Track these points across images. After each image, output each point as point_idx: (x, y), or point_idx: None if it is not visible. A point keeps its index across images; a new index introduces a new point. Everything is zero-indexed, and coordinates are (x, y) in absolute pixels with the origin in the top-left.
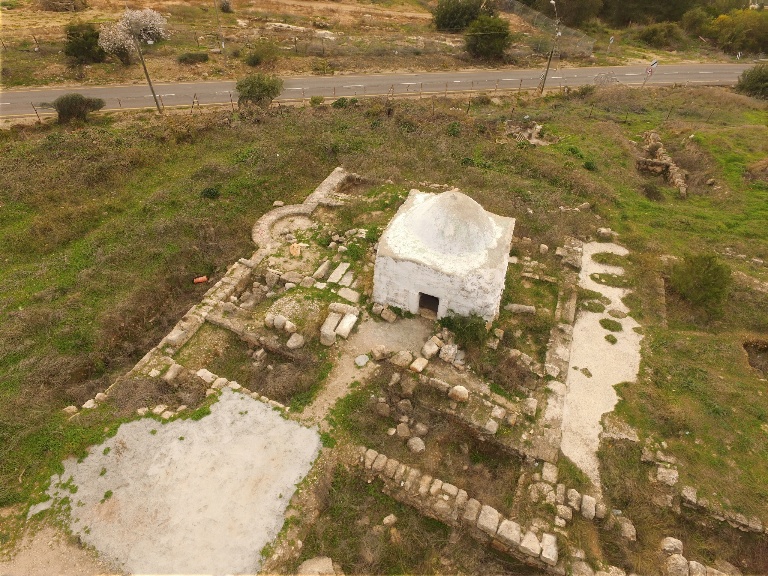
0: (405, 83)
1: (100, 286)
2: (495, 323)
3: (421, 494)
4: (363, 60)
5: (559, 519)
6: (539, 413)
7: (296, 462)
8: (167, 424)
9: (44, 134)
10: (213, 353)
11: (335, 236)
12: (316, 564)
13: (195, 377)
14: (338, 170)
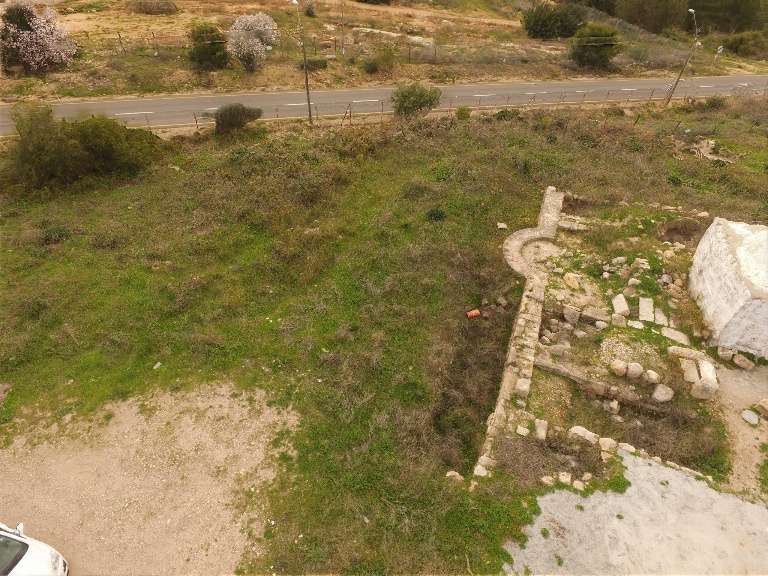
0: (531, 93)
1: (400, 324)
2: None
3: None
4: (475, 68)
5: None
6: None
7: None
8: (589, 498)
9: (206, 146)
10: (564, 405)
11: (607, 266)
12: None
13: (573, 436)
14: (552, 189)
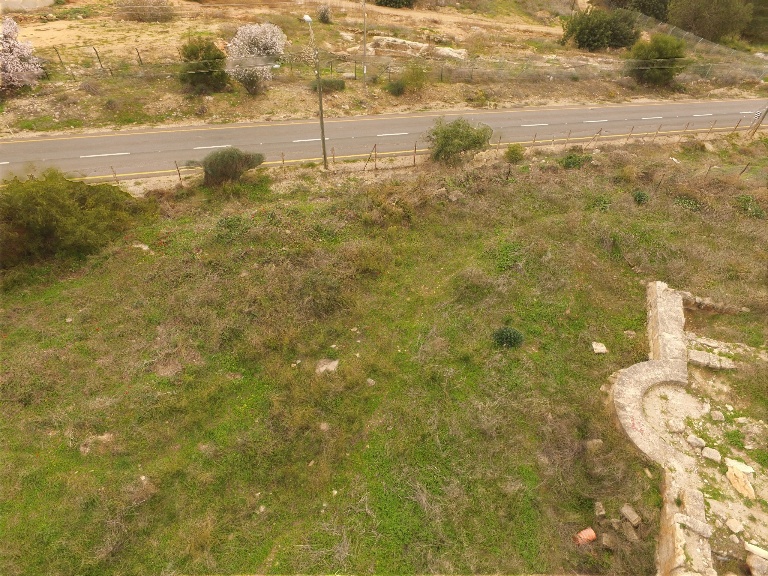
0: (589, 121)
1: None
2: None
3: None
4: (518, 88)
5: None
6: None
7: None
8: None
9: (190, 204)
10: None
11: None
12: None
13: None
14: (664, 287)
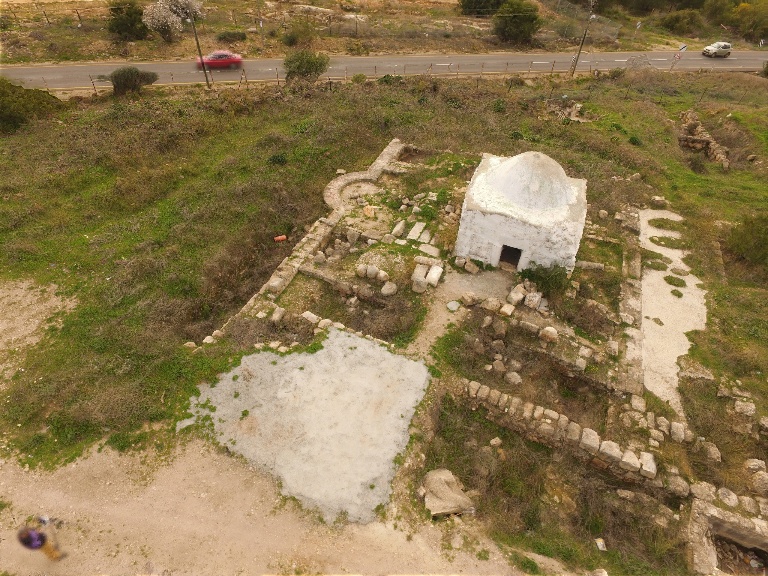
0: (439, 64)
1: (195, 239)
2: (571, 276)
3: (526, 418)
4: (395, 42)
5: (653, 440)
6: (620, 354)
7: (410, 389)
8: (285, 357)
9: (101, 106)
10: (310, 300)
11: (405, 199)
12: (440, 474)
13: (300, 319)
14: (395, 141)
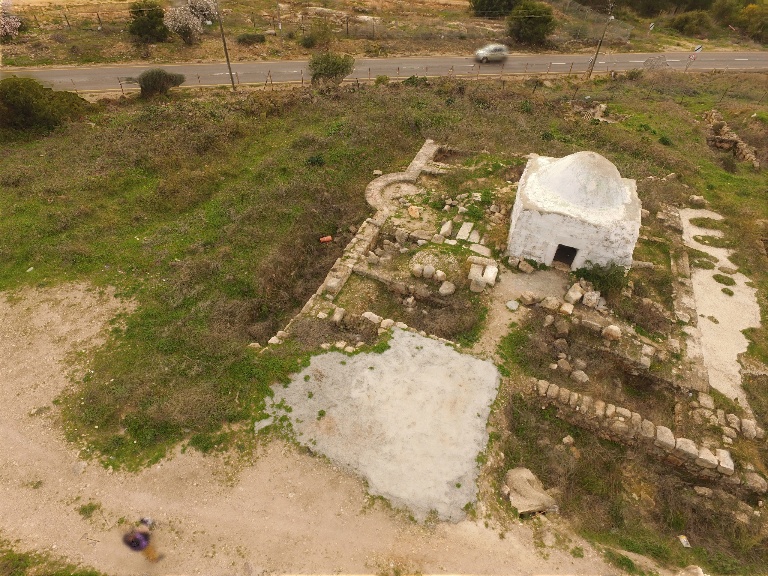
0: (458, 65)
1: (246, 241)
2: None
3: (599, 416)
4: (412, 43)
5: (726, 437)
6: (682, 352)
7: (483, 388)
8: (353, 357)
9: (130, 108)
10: (368, 300)
11: (449, 200)
12: (521, 472)
13: (362, 319)
14: (430, 142)
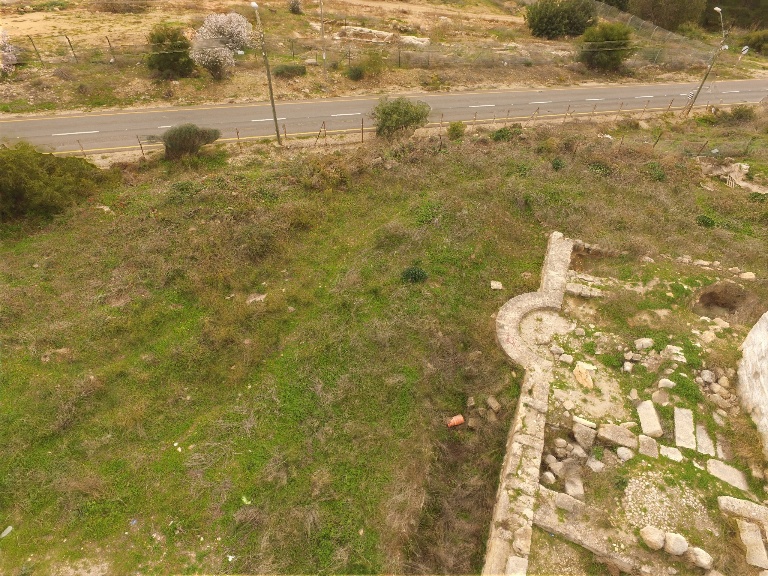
0: (534, 102)
1: (352, 457)
2: None
3: None
4: (473, 73)
5: None
6: None
7: None
8: None
9: (152, 175)
10: None
11: (629, 353)
12: None
13: None
14: (559, 236)
